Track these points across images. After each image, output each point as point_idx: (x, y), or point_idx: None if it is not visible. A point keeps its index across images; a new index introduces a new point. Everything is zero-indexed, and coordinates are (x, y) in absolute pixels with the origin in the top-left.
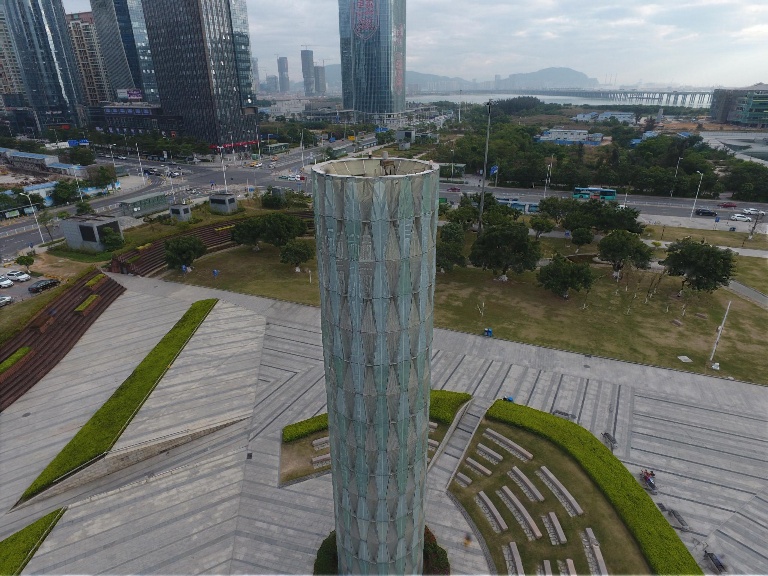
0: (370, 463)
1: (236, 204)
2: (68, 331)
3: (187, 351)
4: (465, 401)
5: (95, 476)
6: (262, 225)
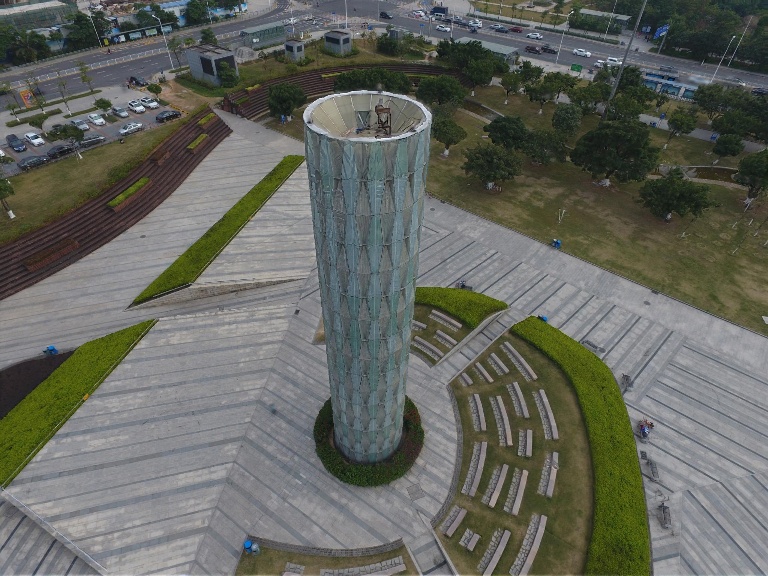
0: (347, 363)
1: (350, 45)
2: (180, 167)
3: (268, 206)
4: (498, 310)
5: (183, 299)
6: (363, 80)
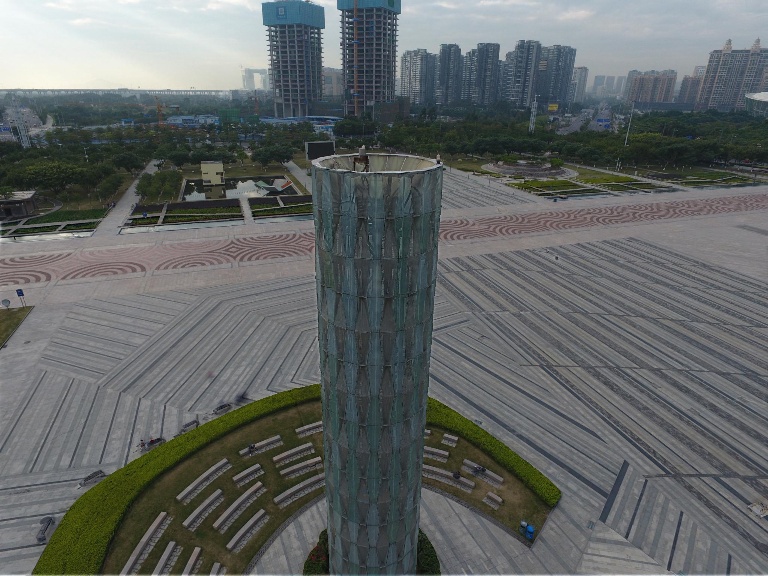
0: None
1: None
2: None
3: None
4: None
5: None
6: None
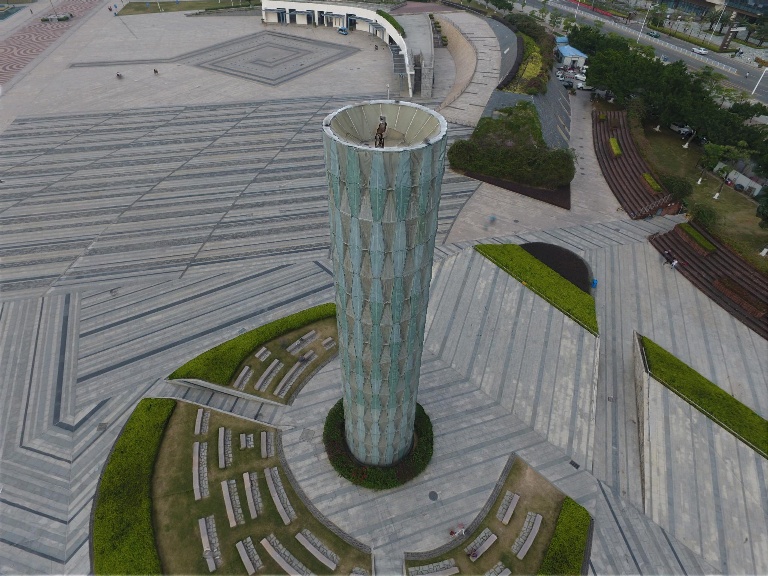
0: None
1: None
2: None
3: None
4: None
5: None
6: None
